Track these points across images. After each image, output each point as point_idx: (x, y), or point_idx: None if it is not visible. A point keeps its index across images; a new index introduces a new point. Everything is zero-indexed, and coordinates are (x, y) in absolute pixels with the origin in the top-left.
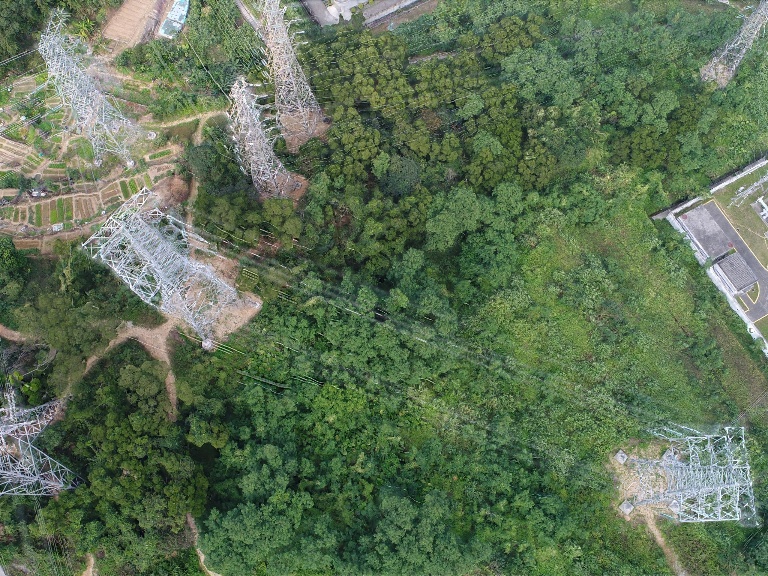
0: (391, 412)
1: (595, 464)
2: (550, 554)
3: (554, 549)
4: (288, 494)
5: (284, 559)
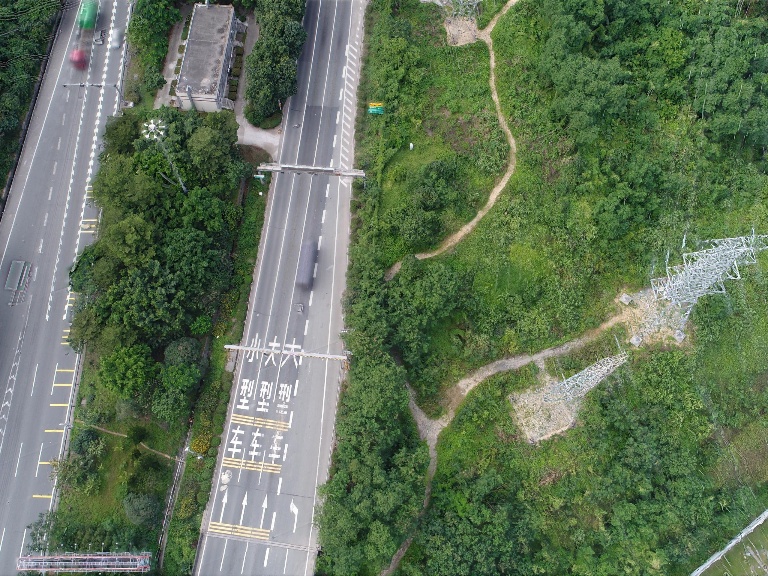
0: (668, 92)
1: (658, 267)
2: (586, 210)
3: (590, 215)
4: (602, 2)
5: (558, 4)
